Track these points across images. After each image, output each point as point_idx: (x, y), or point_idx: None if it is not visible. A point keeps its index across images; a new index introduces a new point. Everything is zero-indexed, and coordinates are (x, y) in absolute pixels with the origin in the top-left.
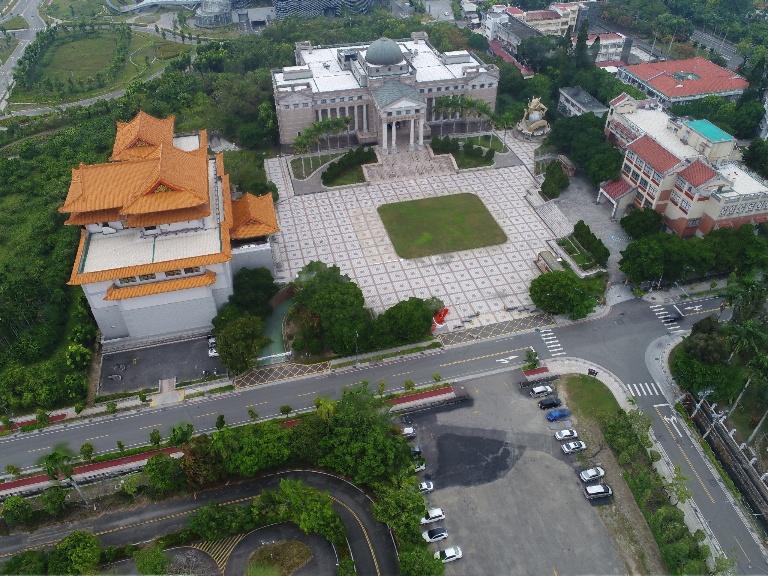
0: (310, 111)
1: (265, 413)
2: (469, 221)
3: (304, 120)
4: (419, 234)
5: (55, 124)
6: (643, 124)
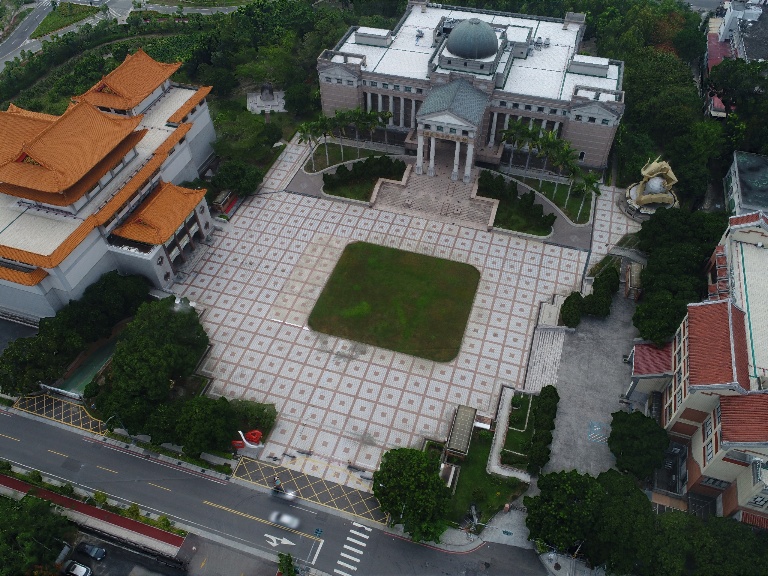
0: (355, 91)
1: (5, 453)
2: (433, 309)
3: (348, 100)
4: (357, 301)
5: (169, 28)
6: (759, 275)
